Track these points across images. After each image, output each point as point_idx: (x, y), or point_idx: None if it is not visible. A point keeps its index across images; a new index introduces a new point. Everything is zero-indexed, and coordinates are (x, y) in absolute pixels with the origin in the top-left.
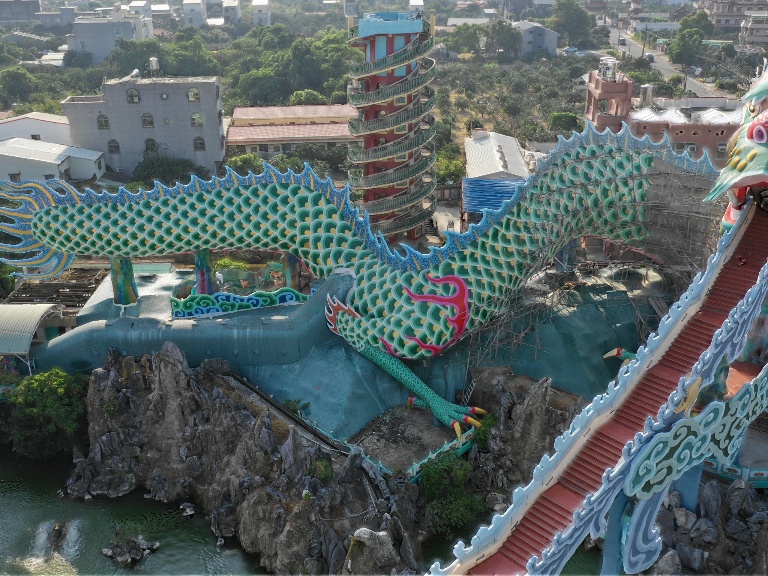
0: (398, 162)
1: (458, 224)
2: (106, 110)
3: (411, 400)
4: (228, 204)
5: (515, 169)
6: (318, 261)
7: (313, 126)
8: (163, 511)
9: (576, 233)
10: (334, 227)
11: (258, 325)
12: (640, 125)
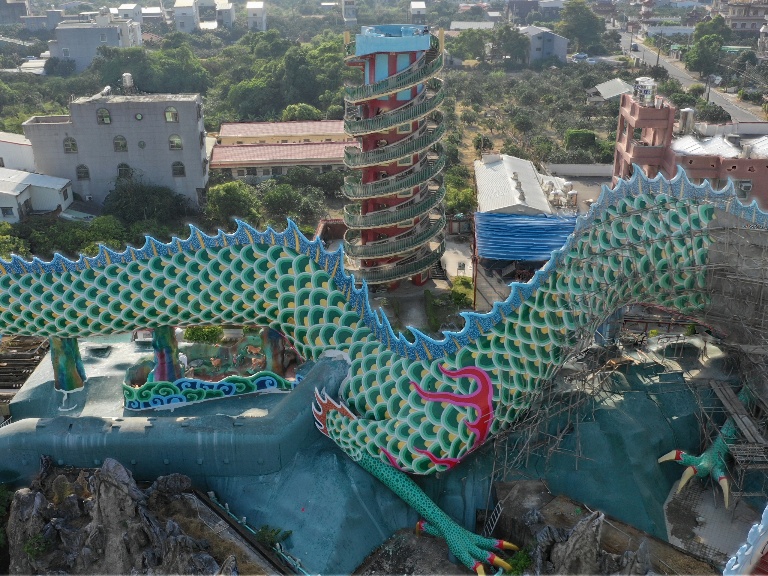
0: (401, 198)
1: (469, 264)
2: (73, 132)
3: (420, 526)
4: (192, 271)
5: (533, 201)
6: (304, 340)
7: (306, 146)
8: None
9: (622, 303)
10: (324, 298)
11: (228, 427)
12: (685, 159)
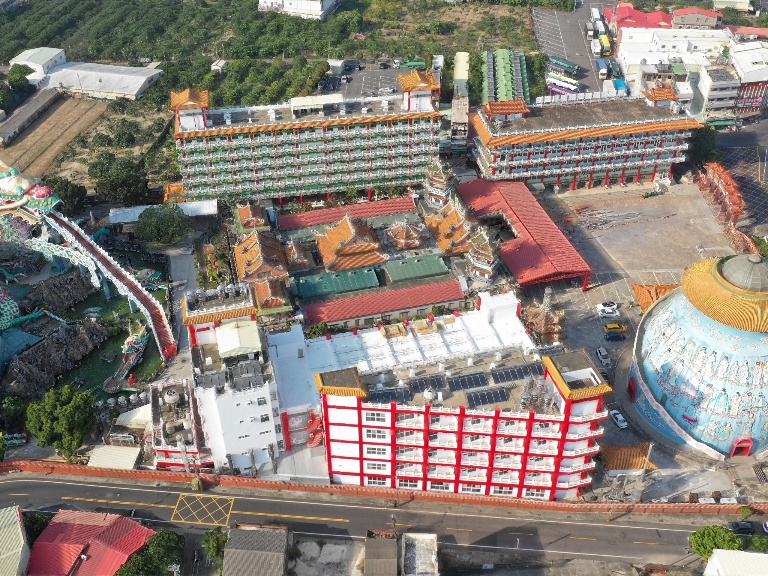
0: None
1: None
2: None
3: None
4: None
5: None
6: None
7: None
8: (59, 384)
9: None
10: None
11: None
12: None
